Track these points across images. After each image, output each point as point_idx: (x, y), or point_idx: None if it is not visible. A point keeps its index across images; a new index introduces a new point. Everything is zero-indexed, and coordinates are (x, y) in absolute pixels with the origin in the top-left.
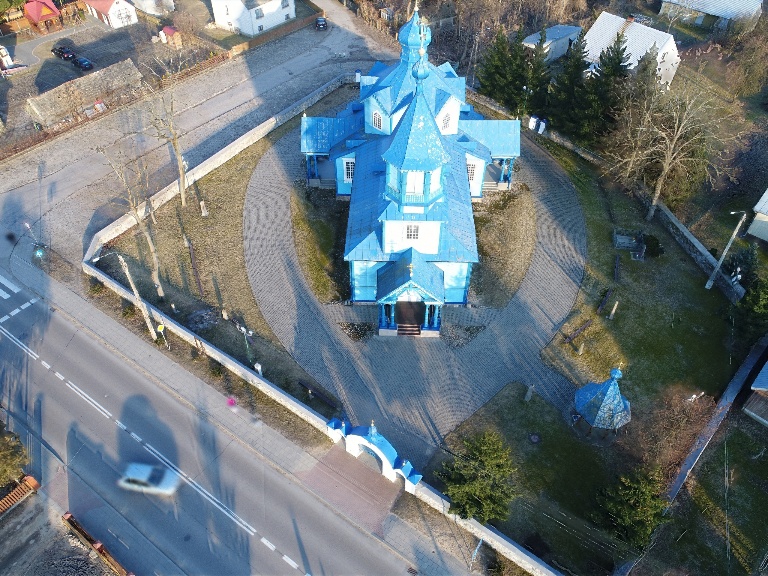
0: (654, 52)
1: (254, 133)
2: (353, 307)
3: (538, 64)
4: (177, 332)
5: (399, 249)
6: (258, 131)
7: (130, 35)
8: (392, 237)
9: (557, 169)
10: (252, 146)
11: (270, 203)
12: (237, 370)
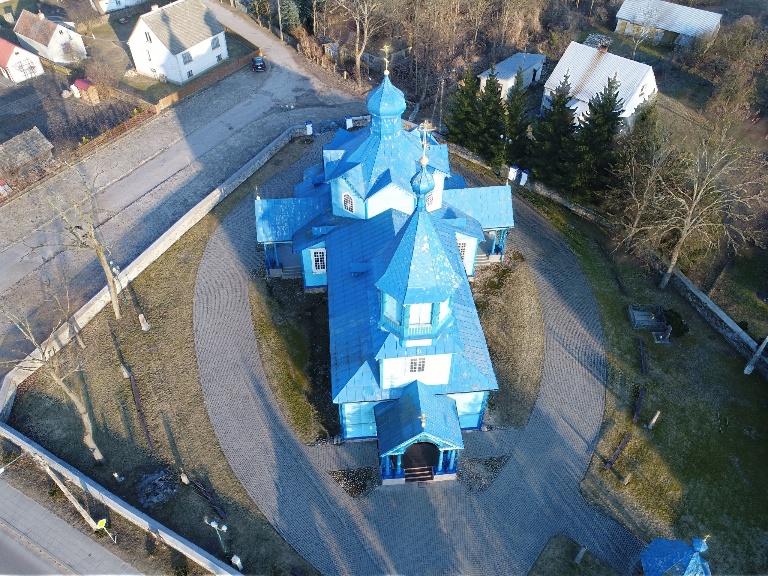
0: (653, 99)
1: (196, 211)
2: (345, 446)
3: (515, 110)
4: (124, 515)
5: (400, 383)
6: (200, 208)
7: (36, 90)
8: (392, 372)
9: (549, 229)
10: (195, 227)
11: (225, 305)
12: (209, 567)
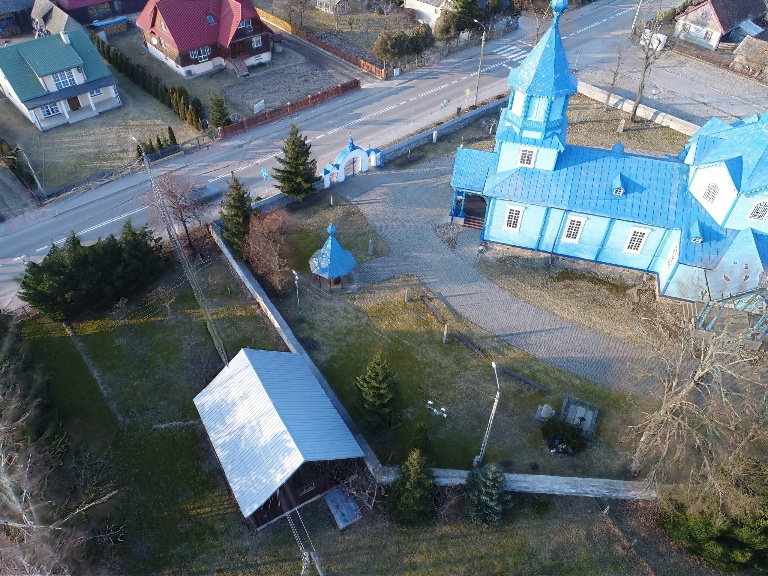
0: None
1: None
2: None
3: None
4: None
5: None
6: None
7: None
8: None
9: None
10: None
11: None
12: None
